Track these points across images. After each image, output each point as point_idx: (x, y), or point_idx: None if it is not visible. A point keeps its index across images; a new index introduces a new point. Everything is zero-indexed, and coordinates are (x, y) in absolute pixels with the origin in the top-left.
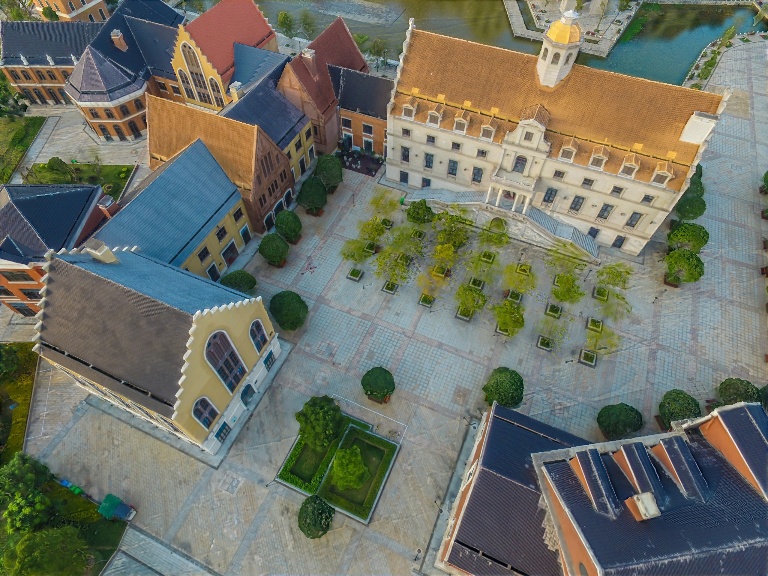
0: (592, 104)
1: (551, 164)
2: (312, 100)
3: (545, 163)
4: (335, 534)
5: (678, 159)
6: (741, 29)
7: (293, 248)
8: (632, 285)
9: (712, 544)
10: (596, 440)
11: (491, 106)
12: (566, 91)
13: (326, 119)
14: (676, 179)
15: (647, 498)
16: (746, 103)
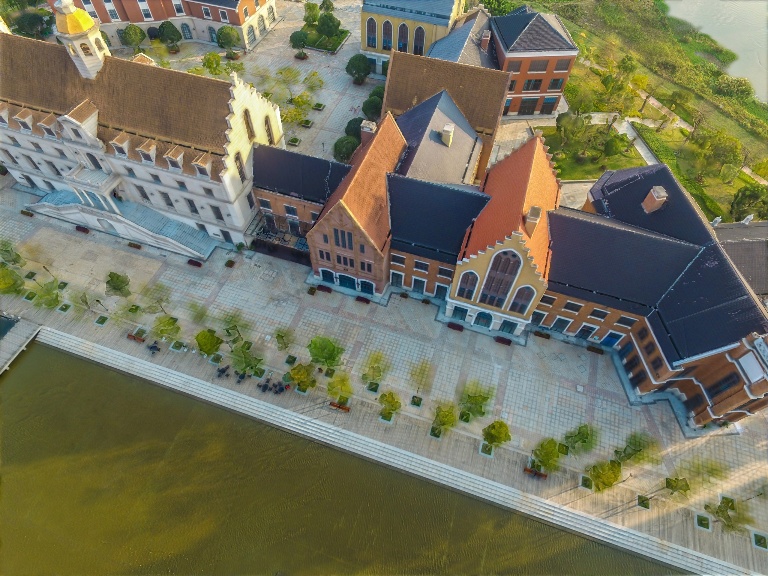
0: None
1: None
2: None
3: None
4: None
5: None
6: None
7: None
8: None
9: None
10: (184, 48)
11: None
12: None
13: None
14: None
15: None
16: None
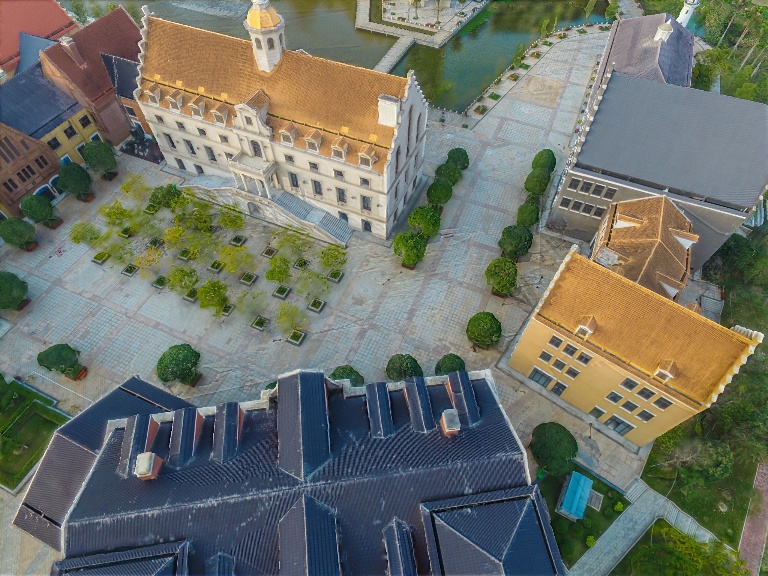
0: (303, 88)
1: (278, 148)
2: (77, 88)
3: (273, 147)
4: None
5: (379, 142)
6: (585, 21)
7: (51, 233)
8: (370, 267)
9: (188, 500)
10: None
11: (221, 92)
12: (280, 76)
13: (99, 107)
14: (379, 161)
15: (144, 457)
16: (557, 92)
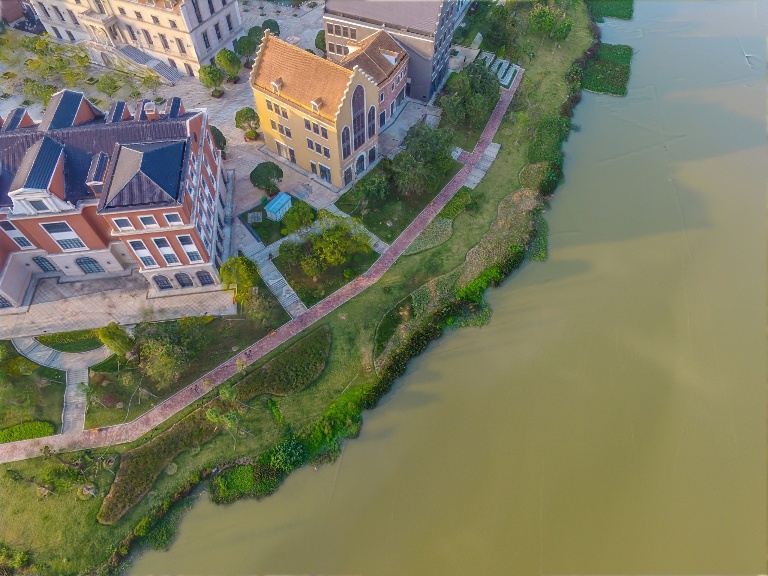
0: None
1: (112, 2)
2: None
3: (109, 1)
4: None
5: None
6: None
7: None
8: (187, 97)
9: None
10: None
11: None
12: None
13: None
14: (177, 4)
15: None
16: None
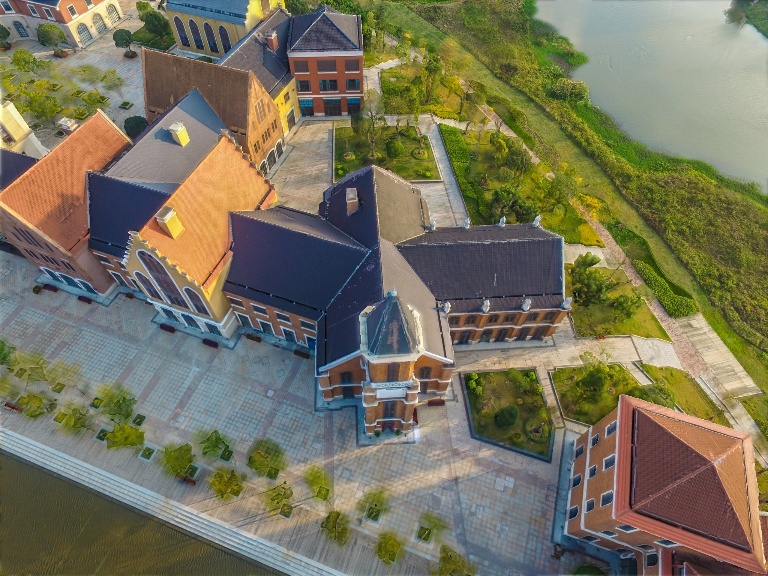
0: None
1: None
2: None
3: None
4: None
5: None
6: None
7: None
8: None
9: None
10: None
11: None
12: None
13: None
14: None
15: None
16: None
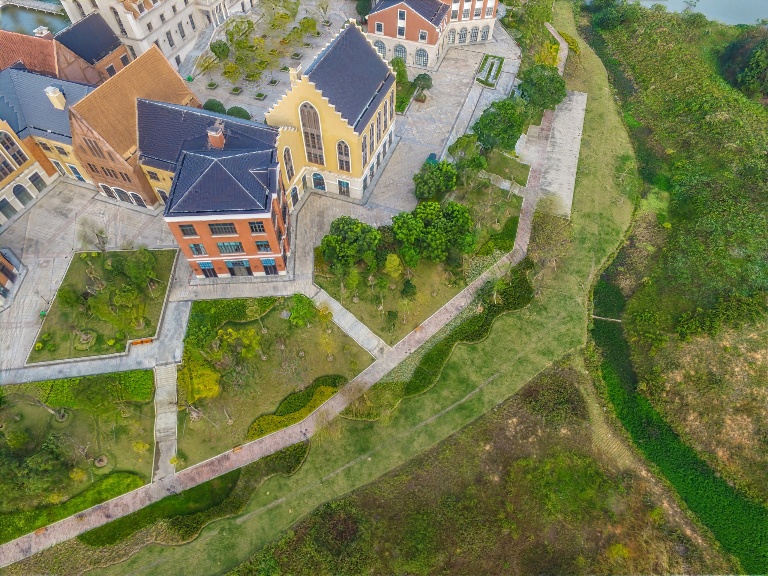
0: None
1: None
2: (87, 63)
3: None
4: (426, 95)
5: None
6: None
7: None
8: (280, 7)
9: None
10: None
11: None
12: None
13: None
14: None
15: None
16: None
